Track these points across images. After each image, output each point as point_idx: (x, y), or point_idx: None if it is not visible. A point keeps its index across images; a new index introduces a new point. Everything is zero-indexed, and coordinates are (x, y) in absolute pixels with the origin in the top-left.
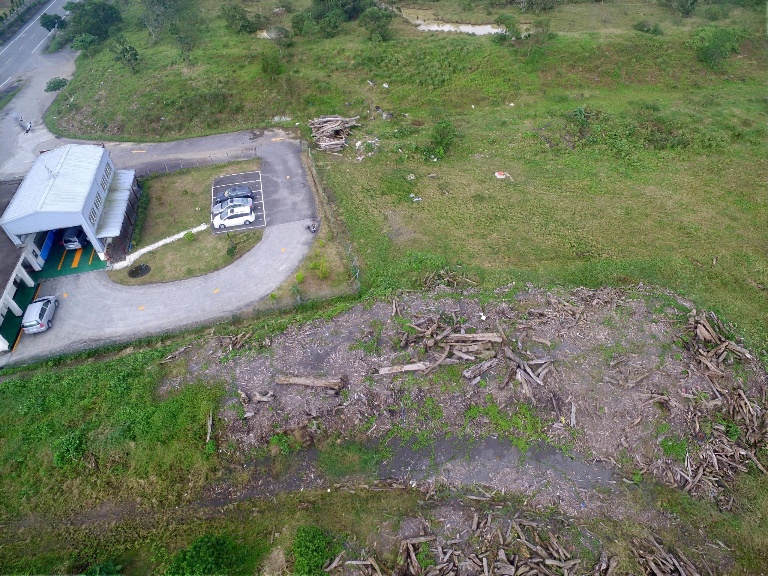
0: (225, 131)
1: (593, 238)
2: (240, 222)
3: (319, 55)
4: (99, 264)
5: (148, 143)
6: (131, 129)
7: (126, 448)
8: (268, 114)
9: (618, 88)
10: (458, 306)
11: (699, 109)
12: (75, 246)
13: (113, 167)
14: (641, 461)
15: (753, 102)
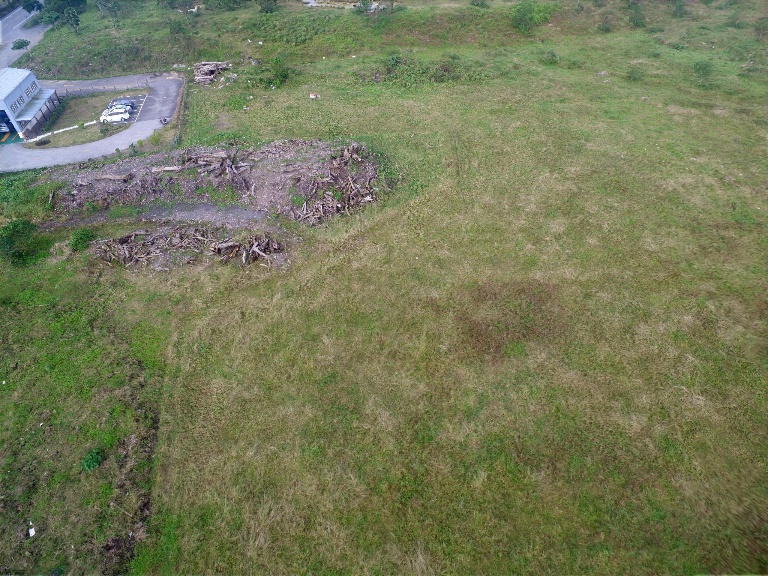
0: (135, 73)
1: (346, 126)
2: (118, 119)
3: (216, 22)
4: (19, 140)
5: (77, 80)
6: (67, 71)
7: (2, 206)
8: (169, 62)
9: (443, 47)
10: (225, 151)
11: (487, 58)
12: (5, 130)
13: (39, 86)
14: (280, 208)
15: (534, 54)
